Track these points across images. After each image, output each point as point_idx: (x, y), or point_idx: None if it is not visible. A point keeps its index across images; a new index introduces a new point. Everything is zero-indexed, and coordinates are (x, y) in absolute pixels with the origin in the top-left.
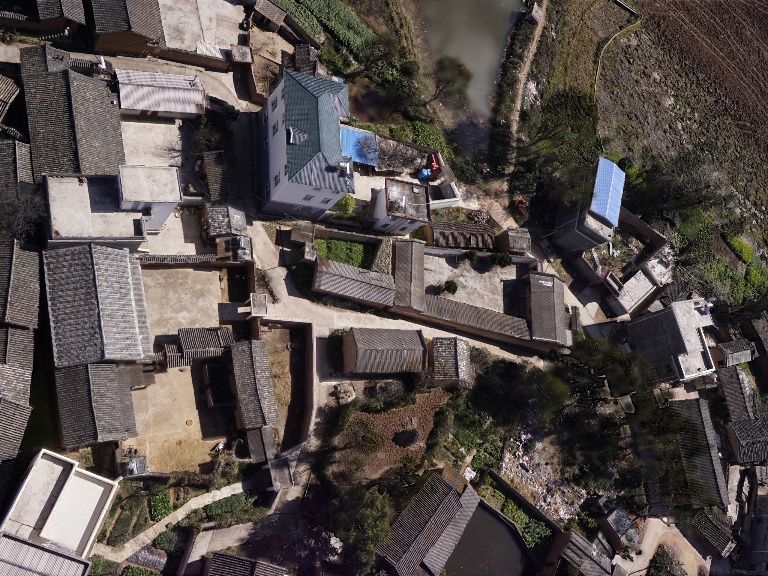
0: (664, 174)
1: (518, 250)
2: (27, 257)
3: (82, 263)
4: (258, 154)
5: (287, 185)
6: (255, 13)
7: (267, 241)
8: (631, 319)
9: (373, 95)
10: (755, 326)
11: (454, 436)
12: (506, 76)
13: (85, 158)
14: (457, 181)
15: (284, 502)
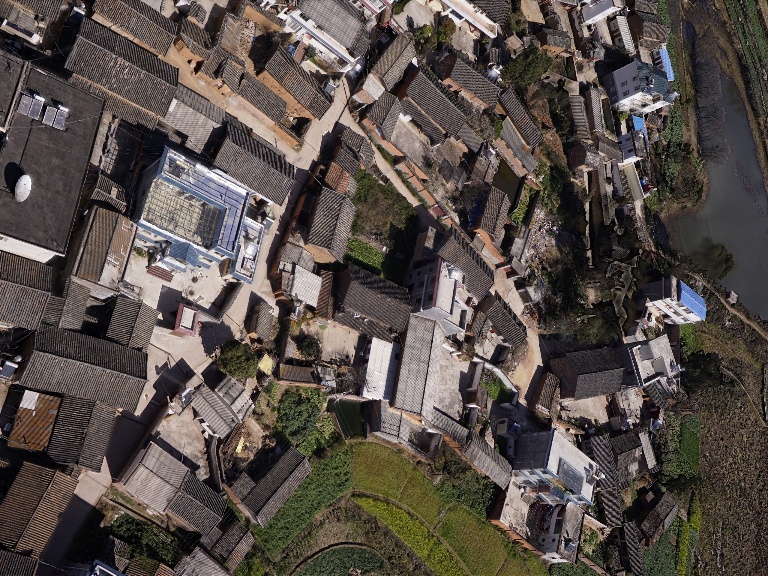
0: None
1: (638, 234)
2: None
3: None
4: None
5: (629, 65)
6: None
7: (592, 78)
8: None
9: (655, 168)
10: (665, 494)
11: (546, 174)
12: None
13: None
14: (644, 212)
15: (510, 53)
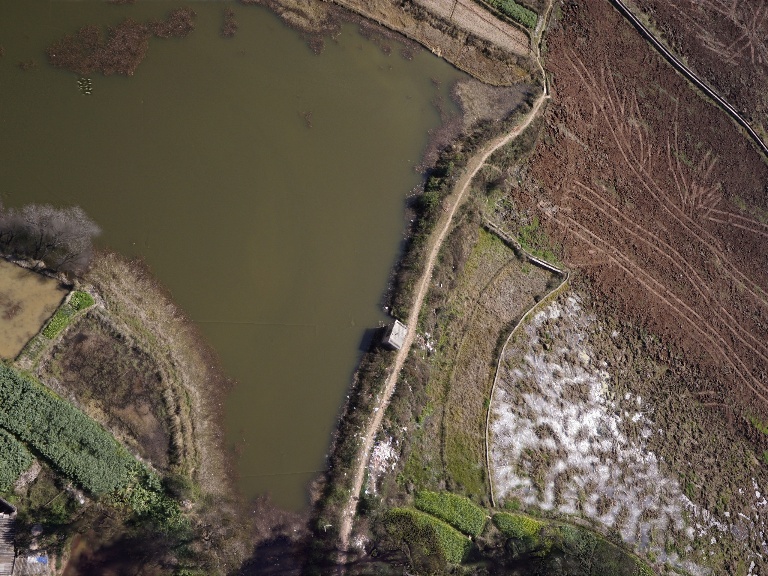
0: (565, 568)
1: None
2: None
3: None
4: None
5: None
6: None
7: None
8: None
9: (114, 543)
10: None
11: None
12: (343, 444)
13: None
14: None
15: None
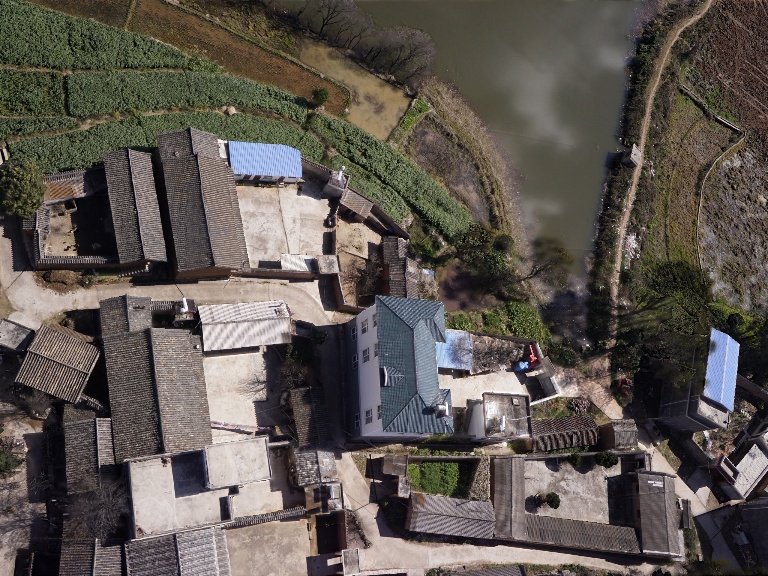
0: None
1: (624, 446)
2: (109, 554)
3: (166, 557)
4: (346, 373)
5: (381, 429)
6: (340, 206)
7: (357, 475)
8: (746, 500)
9: (464, 277)
10: None
11: None
12: (604, 232)
13: (168, 429)
14: (555, 366)
15: None
